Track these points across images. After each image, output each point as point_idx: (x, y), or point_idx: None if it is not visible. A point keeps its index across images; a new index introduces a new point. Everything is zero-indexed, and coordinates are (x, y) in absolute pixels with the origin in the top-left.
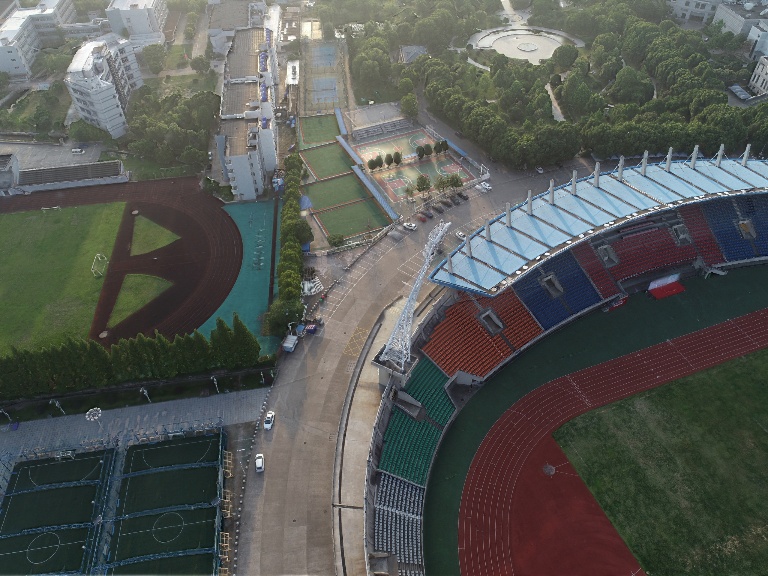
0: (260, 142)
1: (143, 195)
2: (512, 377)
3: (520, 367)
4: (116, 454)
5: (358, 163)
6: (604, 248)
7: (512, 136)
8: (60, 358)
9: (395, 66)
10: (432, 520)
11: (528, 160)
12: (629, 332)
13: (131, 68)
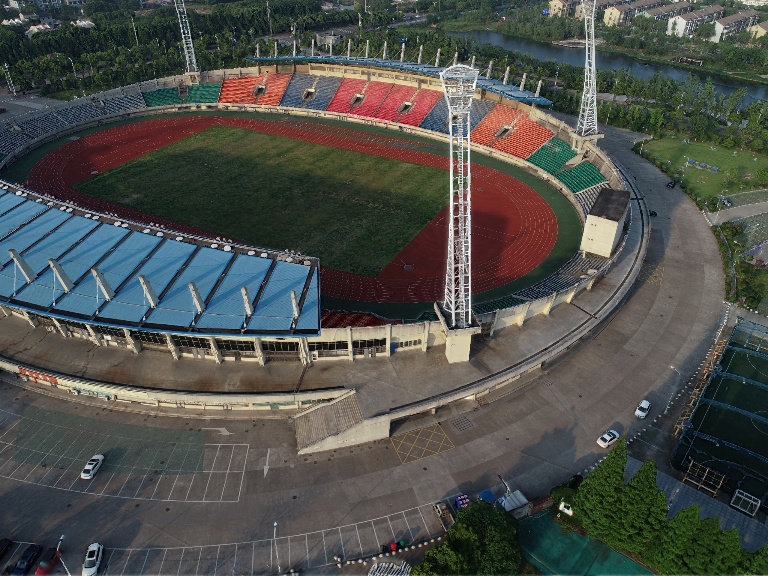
0: None
1: None
2: None
3: None
4: None
5: None
6: None
7: None
8: None
9: None
10: None
11: None
12: None
13: None
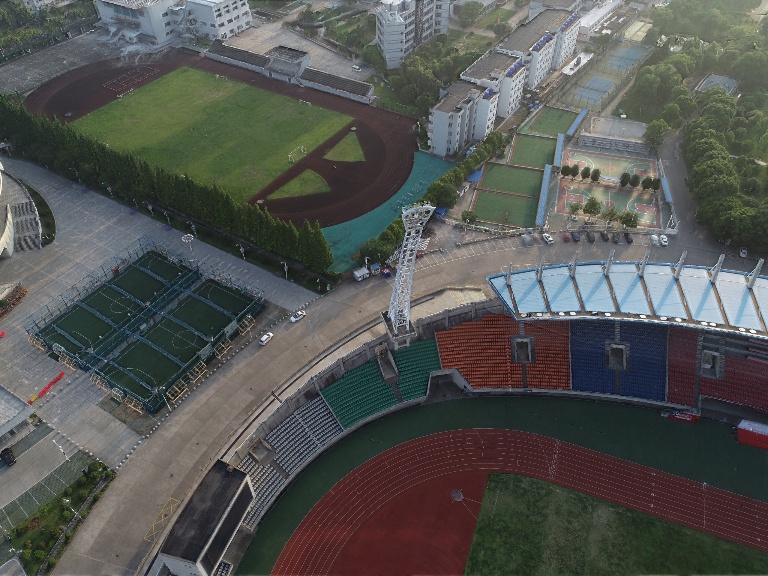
0: (476, 109)
1: (370, 118)
2: (506, 408)
3: (522, 405)
4: (199, 278)
5: (555, 164)
6: (714, 355)
7: (730, 202)
8: (208, 196)
9: (676, 89)
10: (333, 458)
11: (732, 235)
12: (668, 449)
13: (441, 16)
